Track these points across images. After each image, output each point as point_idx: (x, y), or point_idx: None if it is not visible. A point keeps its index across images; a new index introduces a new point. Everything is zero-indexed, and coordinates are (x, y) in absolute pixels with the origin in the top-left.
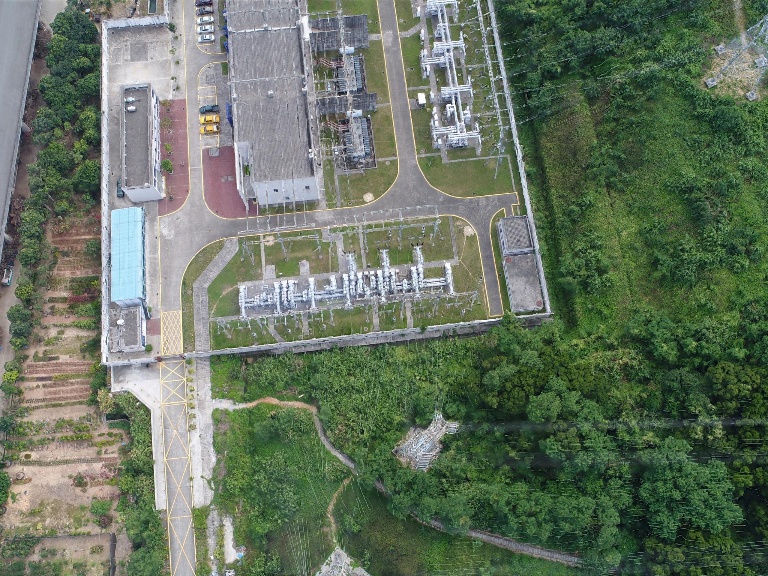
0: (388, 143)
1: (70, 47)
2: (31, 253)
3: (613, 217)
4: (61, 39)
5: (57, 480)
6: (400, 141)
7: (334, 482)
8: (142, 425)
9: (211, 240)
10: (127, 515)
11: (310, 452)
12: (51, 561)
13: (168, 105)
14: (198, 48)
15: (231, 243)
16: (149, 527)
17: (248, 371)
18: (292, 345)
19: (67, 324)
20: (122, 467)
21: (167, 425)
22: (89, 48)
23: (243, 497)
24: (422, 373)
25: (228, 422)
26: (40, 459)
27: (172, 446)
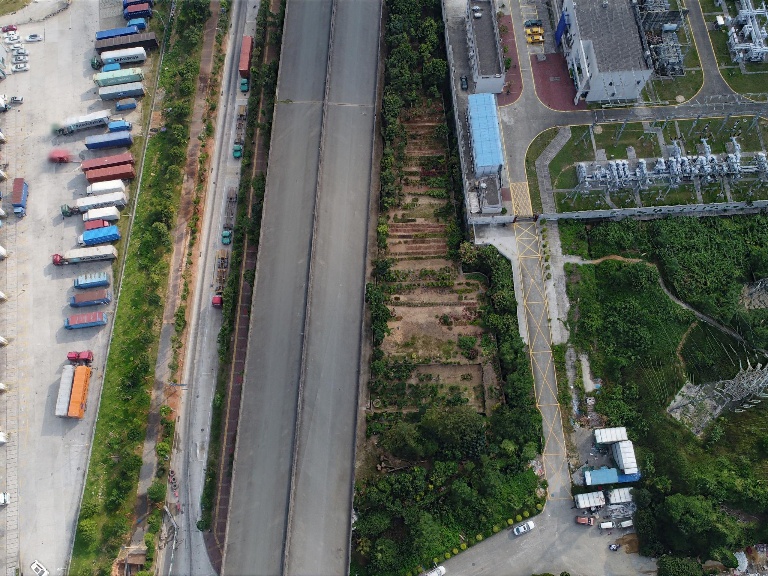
0: (692, 56)
1: None
2: (396, 129)
3: None
4: None
5: (425, 319)
6: (702, 55)
7: (684, 324)
8: (506, 272)
9: (547, 127)
10: (490, 350)
11: (659, 299)
12: None
13: (503, 16)
14: None
15: (564, 130)
16: (518, 357)
17: (594, 232)
18: (629, 214)
19: (421, 193)
20: (481, 311)
21: (525, 274)
22: None
23: (597, 337)
24: (752, 239)
25: (579, 274)
26: (408, 301)
27: (530, 292)
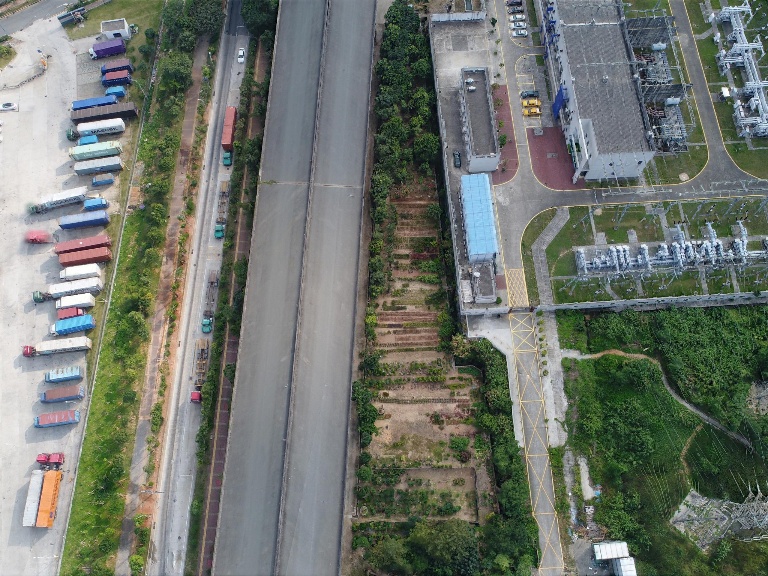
0: (696, 130)
1: (404, 35)
2: (385, 211)
3: None
4: (396, 28)
5: (415, 417)
6: (707, 129)
7: (688, 427)
8: (500, 368)
9: (544, 208)
10: (483, 452)
11: (662, 399)
12: (417, 490)
13: None
14: (513, 42)
15: (562, 211)
16: (513, 462)
17: (593, 325)
18: (630, 304)
19: (412, 278)
20: (475, 408)
21: (520, 370)
22: (418, 37)
23: (596, 439)
24: (760, 333)
25: (578, 370)
26: (398, 397)
27: (526, 390)
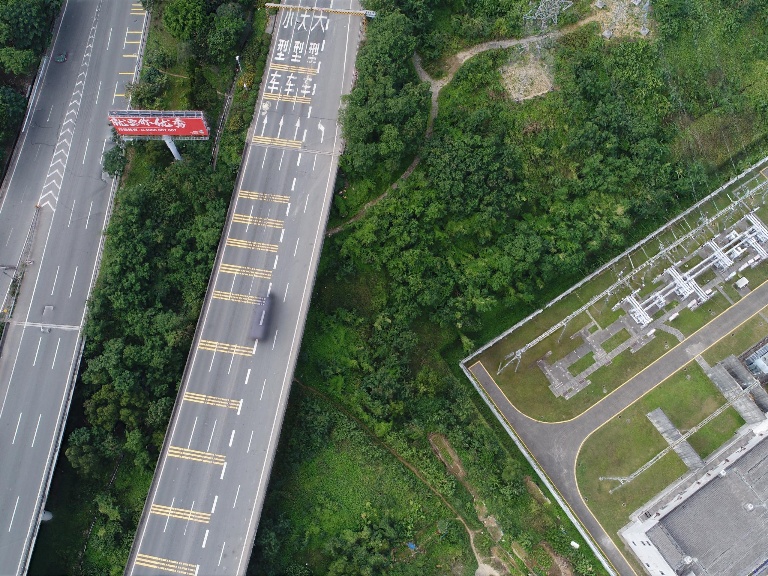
0: None
1: None
2: None
3: (760, 81)
4: None
5: None
6: None
7: None
8: None
9: None
10: None
11: None
12: None
13: None
14: None
15: None
16: None
17: None
18: None
19: None
20: None
21: None
22: None
23: None
24: None
25: None
26: None
27: None
